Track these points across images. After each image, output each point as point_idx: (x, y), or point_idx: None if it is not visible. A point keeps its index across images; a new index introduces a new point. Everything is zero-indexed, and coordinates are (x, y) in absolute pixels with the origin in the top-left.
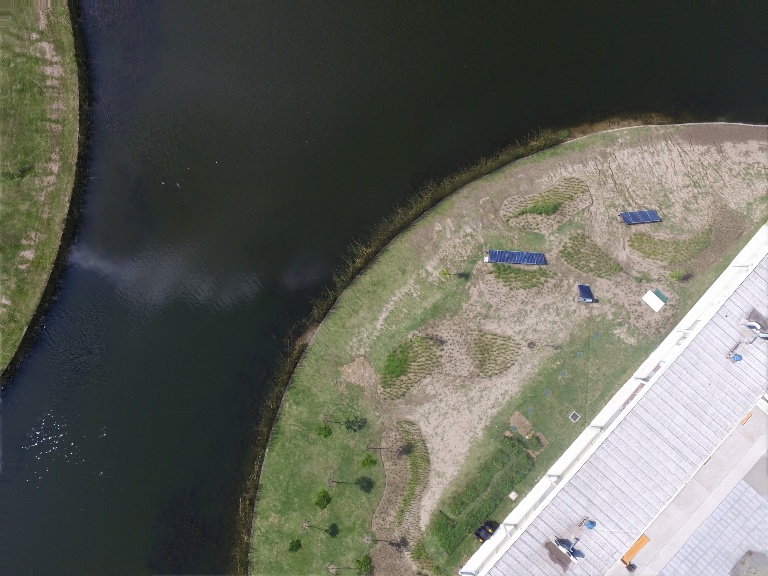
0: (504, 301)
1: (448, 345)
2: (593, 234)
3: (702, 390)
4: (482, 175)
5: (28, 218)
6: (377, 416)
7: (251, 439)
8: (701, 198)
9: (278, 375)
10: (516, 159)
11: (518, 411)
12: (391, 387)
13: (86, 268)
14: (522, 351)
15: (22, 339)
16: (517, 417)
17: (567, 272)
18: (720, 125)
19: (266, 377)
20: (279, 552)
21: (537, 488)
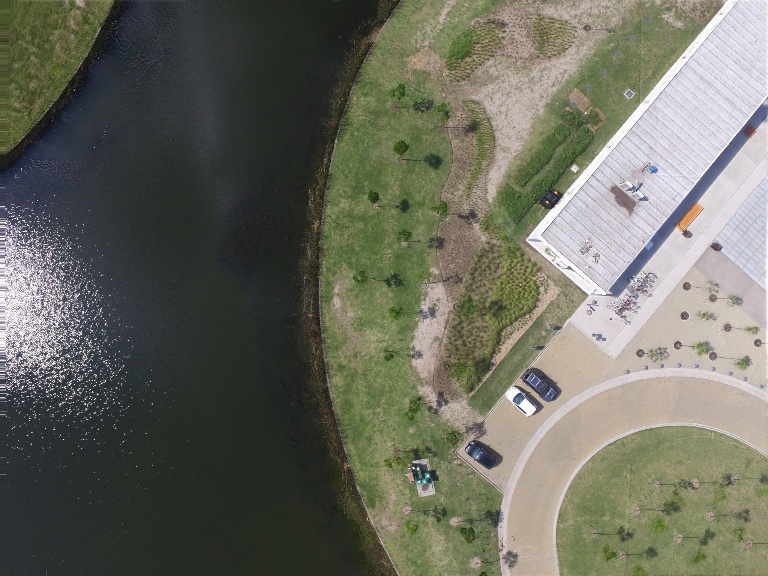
0: None
1: (509, 27)
2: None
3: (749, 47)
4: None
5: None
6: (443, 97)
7: (320, 134)
8: None
9: (348, 61)
10: None
11: (577, 88)
12: (456, 69)
13: None
14: (578, 34)
15: (95, 40)
16: (576, 94)
17: None
18: None
19: (333, 75)
20: (350, 235)
21: (597, 159)
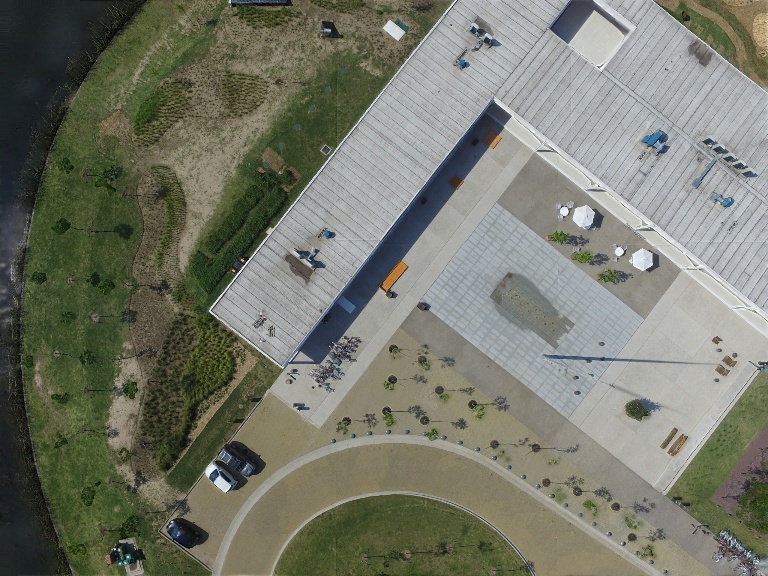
0: (248, 40)
1: (196, 87)
2: None
3: (432, 97)
4: None
5: None
6: (132, 163)
7: None
8: None
9: (34, 131)
10: None
11: (269, 147)
12: (144, 133)
13: None
14: (270, 89)
15: None
16: (269, 153)
17: (311, 11)
18: None
19: None
20: (47, 311)
21: None
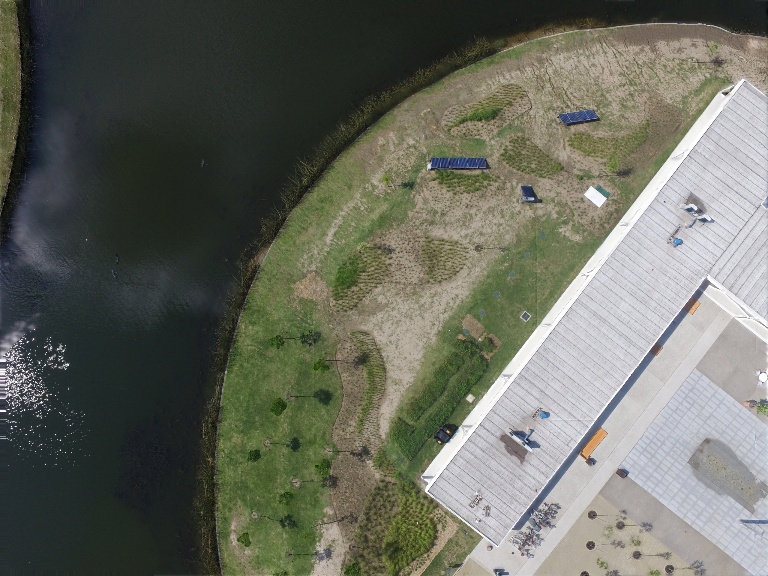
0: (449, 206)
1: (396, 253)
2: (533, 136)
3: (645, 276)
4: (422, 88)
5: None
6: (331, 329)
7: (210, 363)
8: (637, 95)
9: (231, 295)
10: (455, 70)
11: (469, 314)
12: (343, 299)
13: (36, 204)
14: (470, 255)
15: None
16: (469, 320)
17: (509, 175)
18: (653, 26)
19: (221, 301)
20: (243, 472)
21: (493, 388)
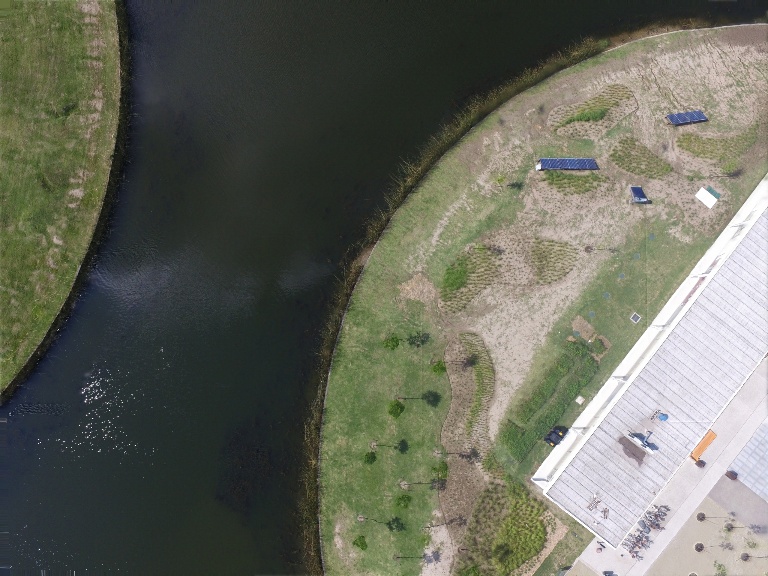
0: (559, 207)
1: (506, 254)
2: (642, 137)
3: (763, 277)
4: (527, 87)
5: (75, 156)
6: (439, 330)
7: (312, 365)
8: (745, 96)
9: (338, 296)
10: (559, 70)
11: (579, 315)
12: (452, 300)
13: (136, 204)
14: (580, 256)
15: (76, 278)
16: (579, 321)
17: (619, 175)
18: (757, 26)
19: (324, 302)
20: (348, 474)
21: (603, 390)
